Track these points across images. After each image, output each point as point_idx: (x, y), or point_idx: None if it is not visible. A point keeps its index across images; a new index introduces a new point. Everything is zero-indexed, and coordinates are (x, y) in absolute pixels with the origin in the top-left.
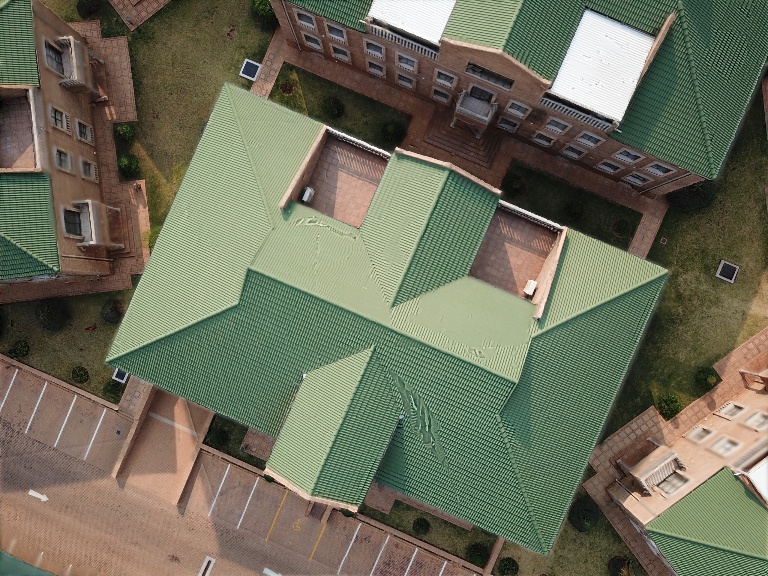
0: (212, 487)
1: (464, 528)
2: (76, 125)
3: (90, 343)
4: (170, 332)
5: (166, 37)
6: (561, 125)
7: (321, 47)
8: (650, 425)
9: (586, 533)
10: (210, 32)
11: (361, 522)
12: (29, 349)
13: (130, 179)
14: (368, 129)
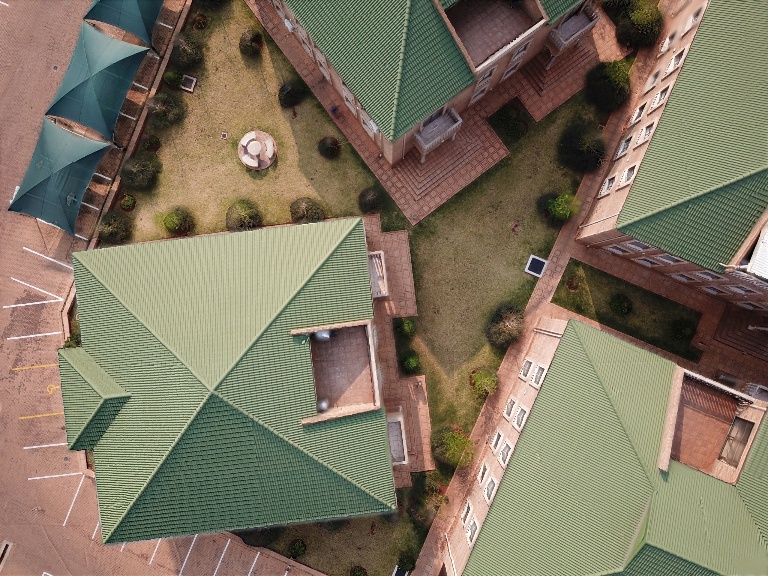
0: None
1: None
2: (375, 333)
3: (369, 542)
4: None
5: (448, 231)
6: None
7: (624, 254)
8: None
9: None
10: (494, 227)
11: None
12: (306, 548)
13: (410, 375)
14: (657, 326)
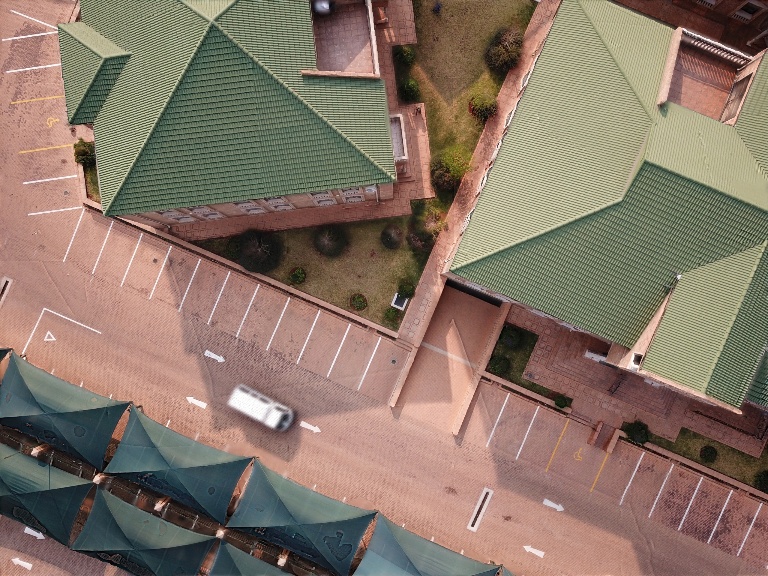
0: (490, 417)
1: (752, 456)
2: None
3: (368, 270)
4: (534, 235)
5: None
6: None
7: None
8: None
9: None
10: None
11: (645, 451)
12: (306, 276)
13: (410, 102)
14: None
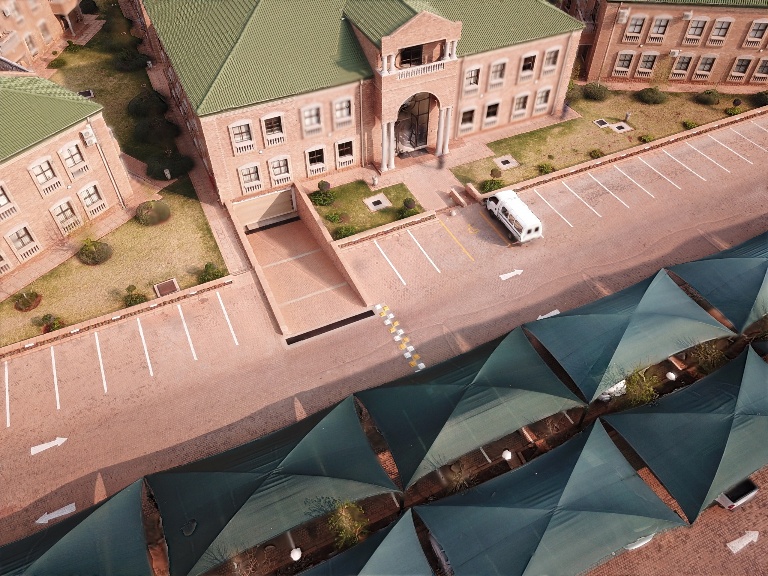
0: None
1: None
2: None
3: None
4: None
5: None
6: None
7: None
8: (78, 41)
9: None
10: None
11: None
12: None
13: None
14: None
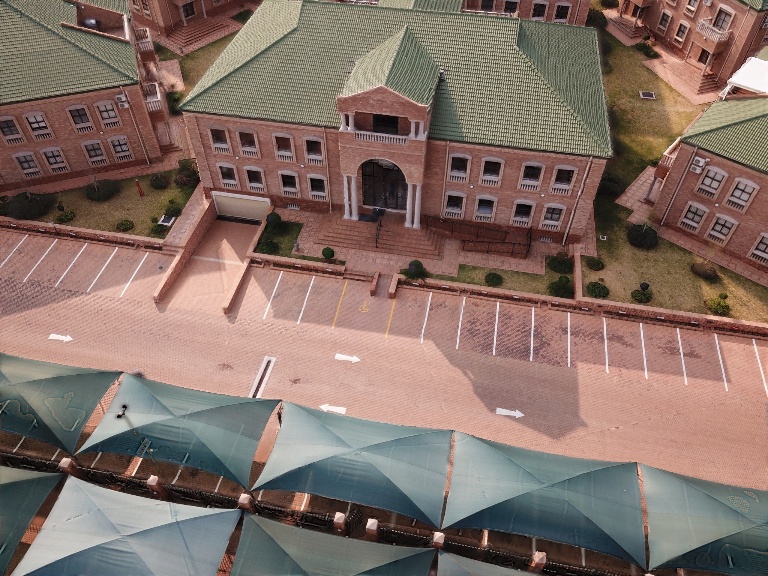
0: (265, 293)
1: (537, 274)
2: None
3: (137, 205)
4: (240, 65)
5: (207, 56)
6: (489, 6)
7: None
8: None
9: (654, 252)
10: None
11: (431, 290)
12: (74, 216)
13: (179, 114)
14: None
